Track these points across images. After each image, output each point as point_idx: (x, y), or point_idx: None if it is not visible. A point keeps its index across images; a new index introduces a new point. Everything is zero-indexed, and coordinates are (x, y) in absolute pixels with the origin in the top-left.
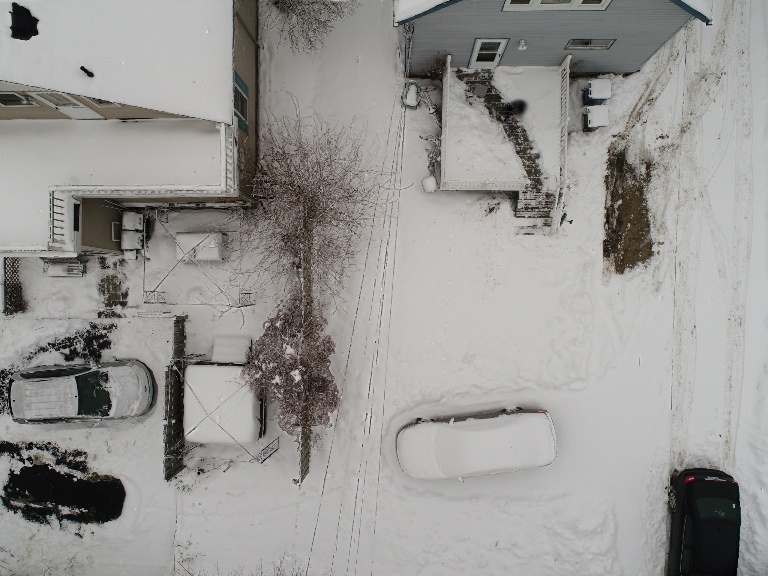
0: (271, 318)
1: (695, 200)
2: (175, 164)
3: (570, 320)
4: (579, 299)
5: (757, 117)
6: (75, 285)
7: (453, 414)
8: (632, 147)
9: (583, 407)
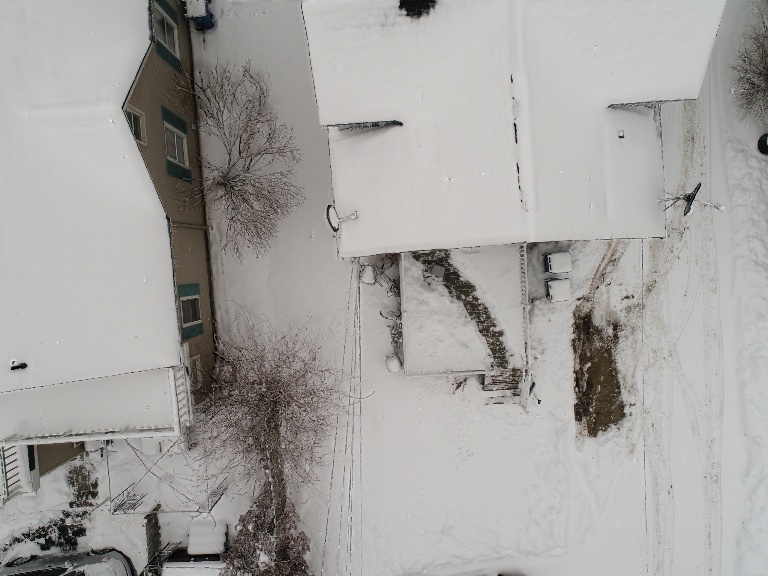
0: (243, 515)
1: (664, 359)
2: (127, 401)
3: (546, 487)
4: (553, 468)
5: (723, 272)
6: (43, 480)
7: None
8: (598, 309)
9: (564, 571)
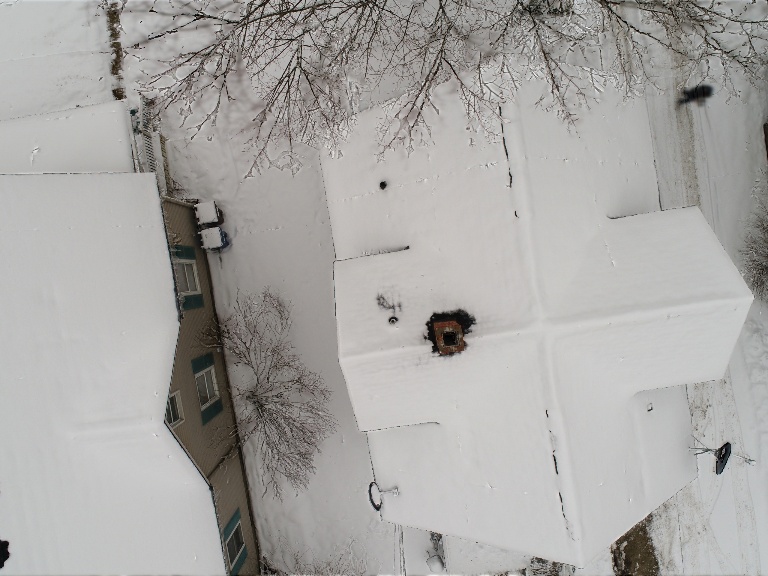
0: None
1: (699, 534)
2: None
3: None
4: None
5: (748, 446)
6: None
7: None
8: None
9: None
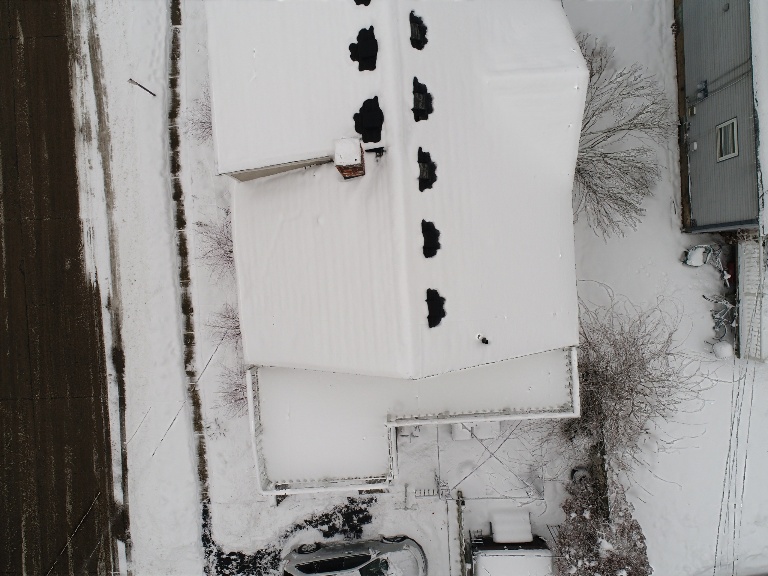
0: (569, 503)
1: None
2: (508, 382)
3: None
4: None
5: None
6: None
7: (745, 575)
8: None
9: None
